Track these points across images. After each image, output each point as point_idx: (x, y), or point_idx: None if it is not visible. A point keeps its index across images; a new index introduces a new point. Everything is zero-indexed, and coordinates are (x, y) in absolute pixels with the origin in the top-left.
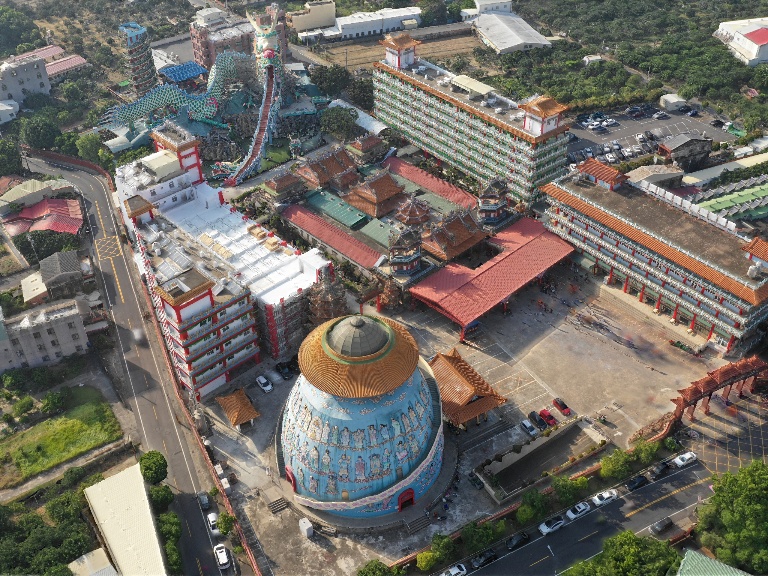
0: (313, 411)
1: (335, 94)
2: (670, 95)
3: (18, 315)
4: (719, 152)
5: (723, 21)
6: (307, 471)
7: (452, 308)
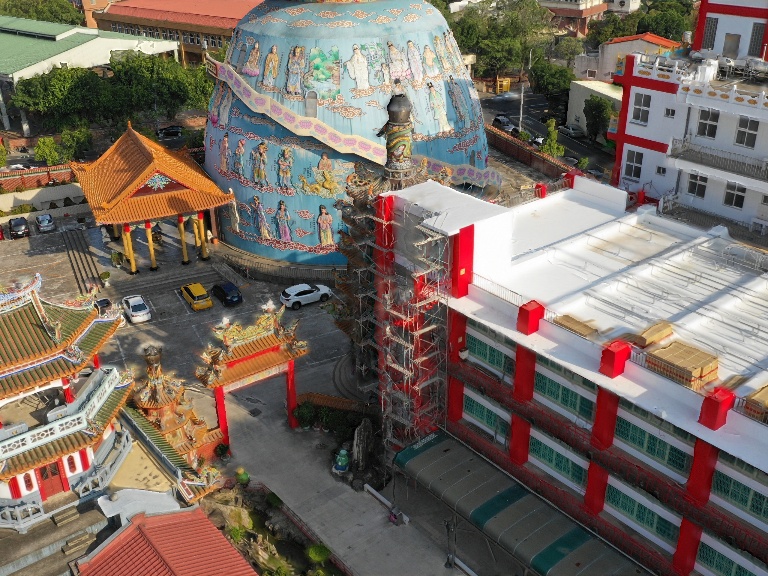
0: None
1: None
2: None
3: None
4: None
5: None
6: None
7: None
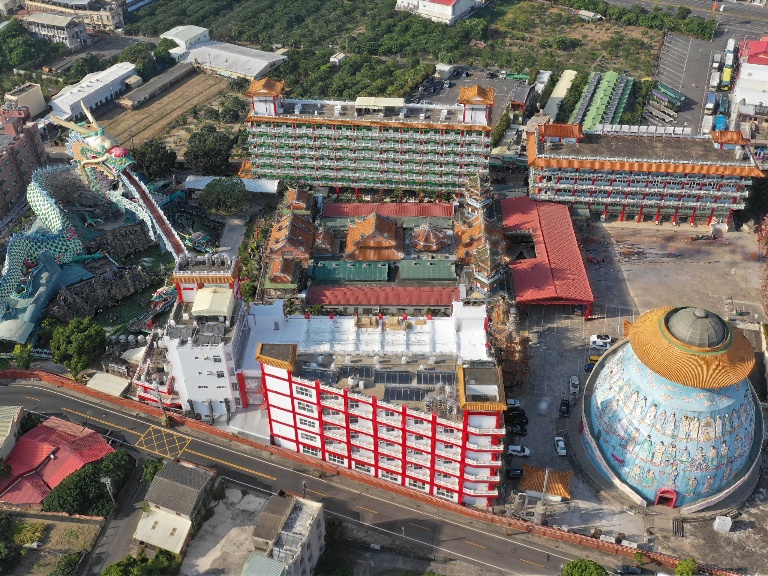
0: (700, 416)
1: (167, 174)
2: (439, 65)
3: (181, 574)
4: None
5: None
6: (704, 475)
7: (570, 294)
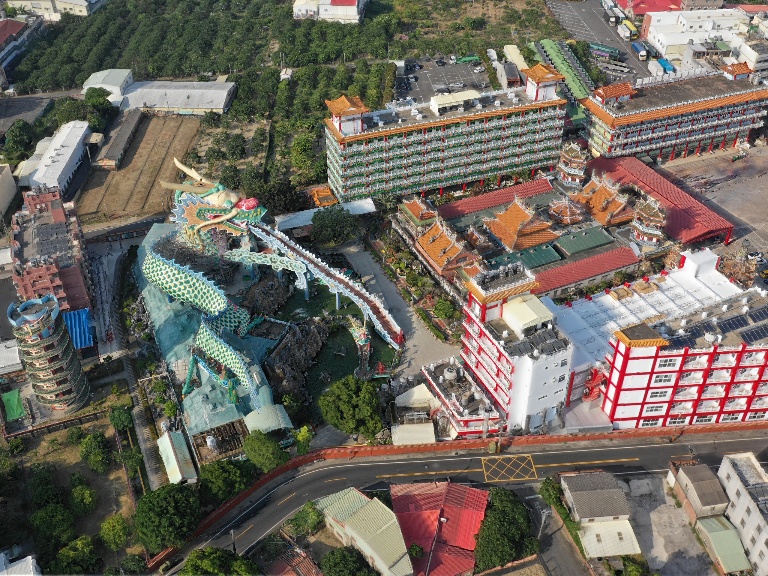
0: None
1: None
2: None
3: (652, 571)
4: (485, 75)
5: (269, 8)
6: None
7: (716, 226)
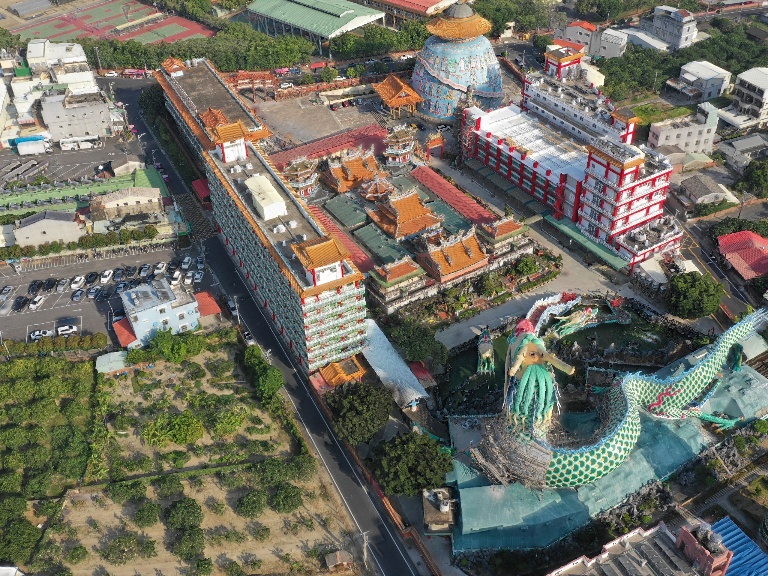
0: None
1: None
2: None
3: None
4: None
5: None
6: None
7: None
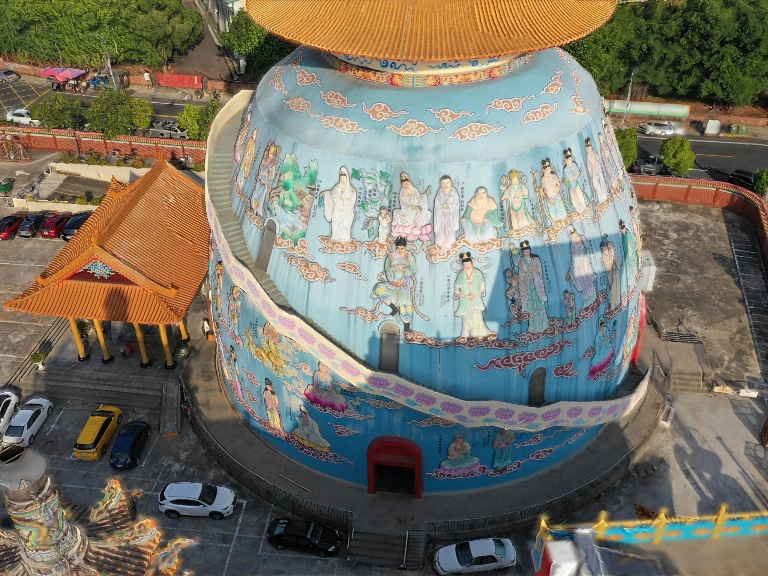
0: None
1: None
2: None
3: None
4: None
5: None
6: None
7: None
